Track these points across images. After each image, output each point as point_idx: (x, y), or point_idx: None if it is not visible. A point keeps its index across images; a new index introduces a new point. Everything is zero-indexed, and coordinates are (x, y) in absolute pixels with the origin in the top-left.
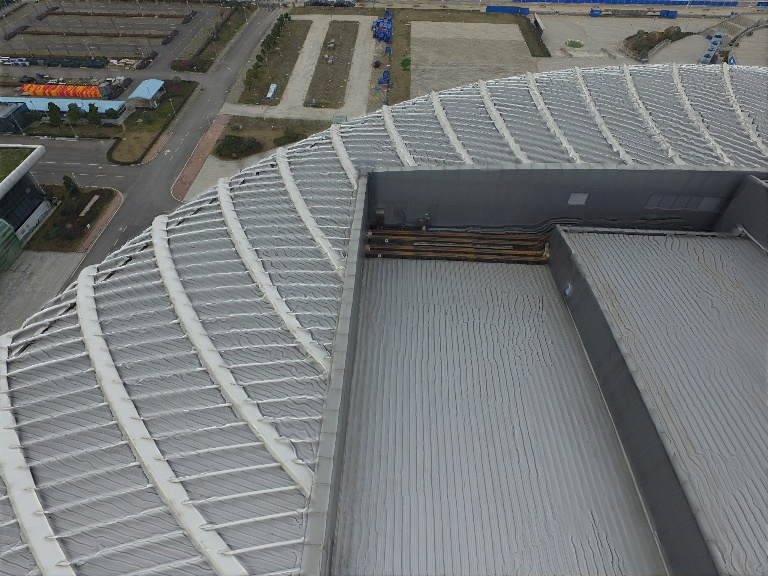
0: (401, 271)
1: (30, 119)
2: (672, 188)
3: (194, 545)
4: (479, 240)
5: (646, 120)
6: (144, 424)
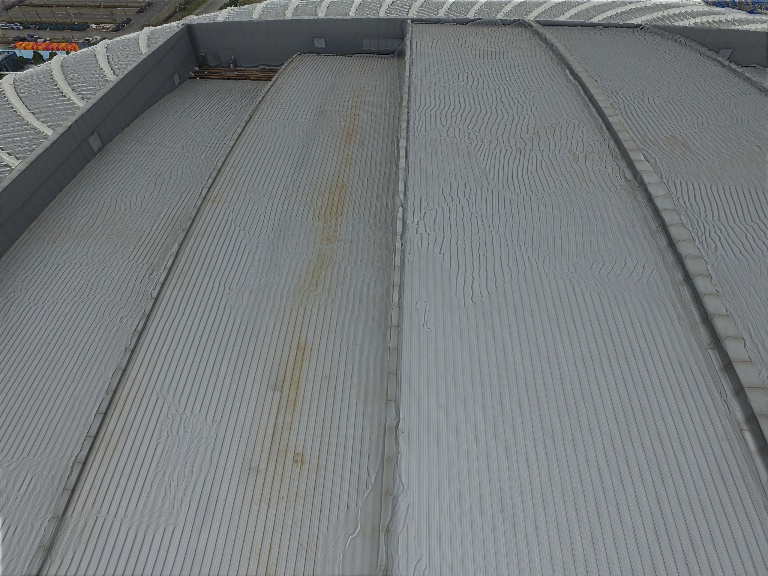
0: (206, 83)
1: (19, 66)
2: (371, 32)
3: (30, 123)
4: (264, 72)
5: (383, 2)
6: (22, 103)
